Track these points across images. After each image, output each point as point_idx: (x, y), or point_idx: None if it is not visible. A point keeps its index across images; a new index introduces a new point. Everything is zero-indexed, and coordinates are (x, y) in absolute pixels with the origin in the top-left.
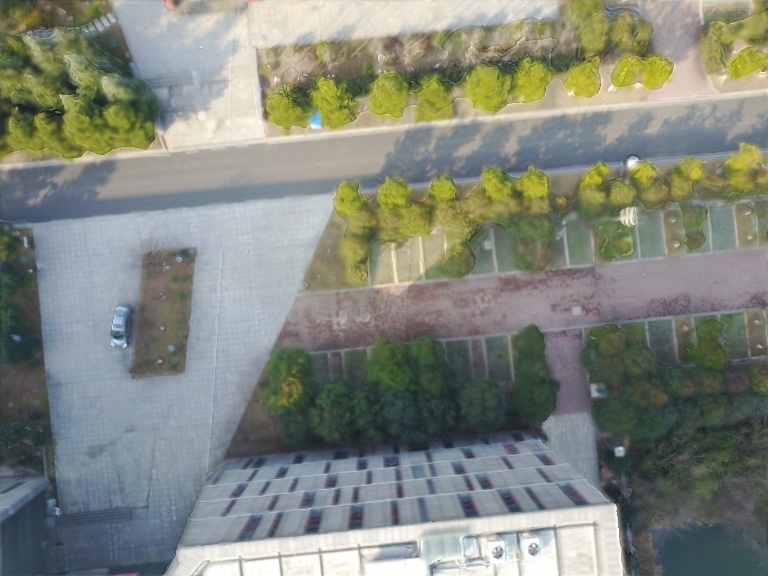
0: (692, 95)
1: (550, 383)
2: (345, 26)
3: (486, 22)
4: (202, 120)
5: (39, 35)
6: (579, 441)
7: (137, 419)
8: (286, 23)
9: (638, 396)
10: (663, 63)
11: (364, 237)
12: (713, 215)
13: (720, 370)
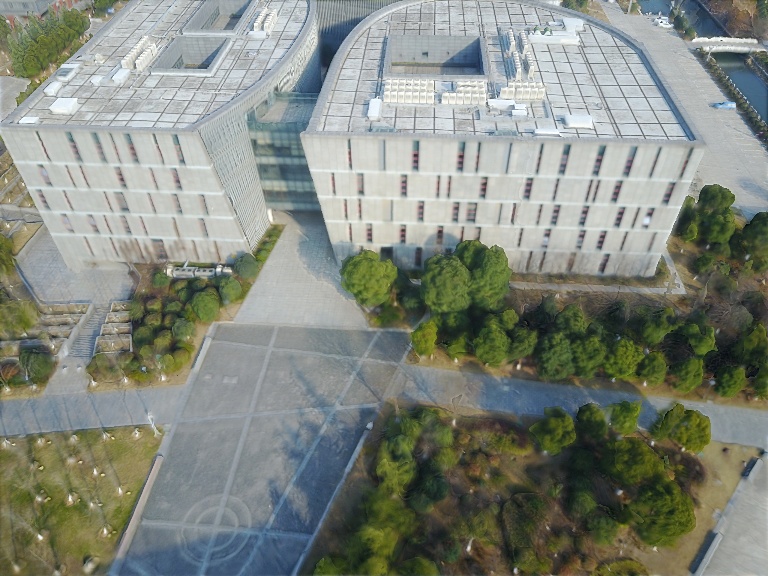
0: None
1: None
2: None
3: None
4: None
5: None
6: None
7: None
8: None
9: None
10: None
11: None
12: None
13: None
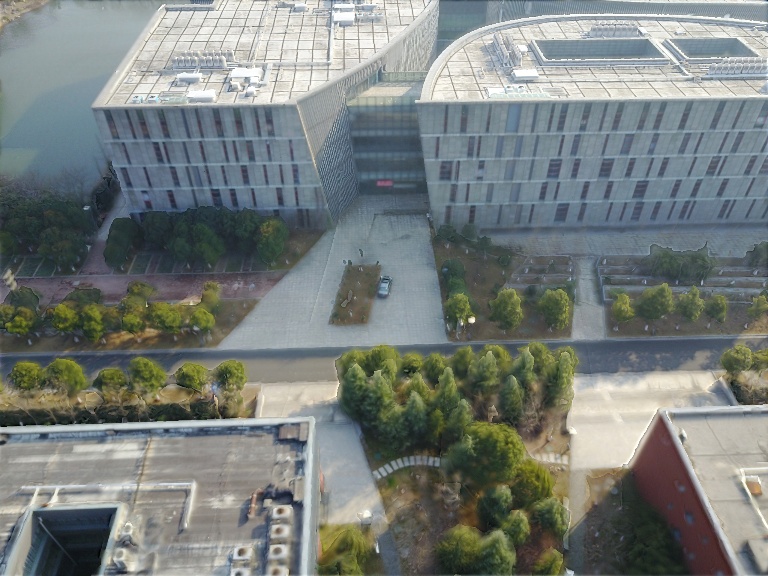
0: None
1: None
2: None
3: None
4: None
5: (433, 446)
6: None
7: (378, 248)
8: None
9: (61, 217)
10: None
11: None
12: None
13: None
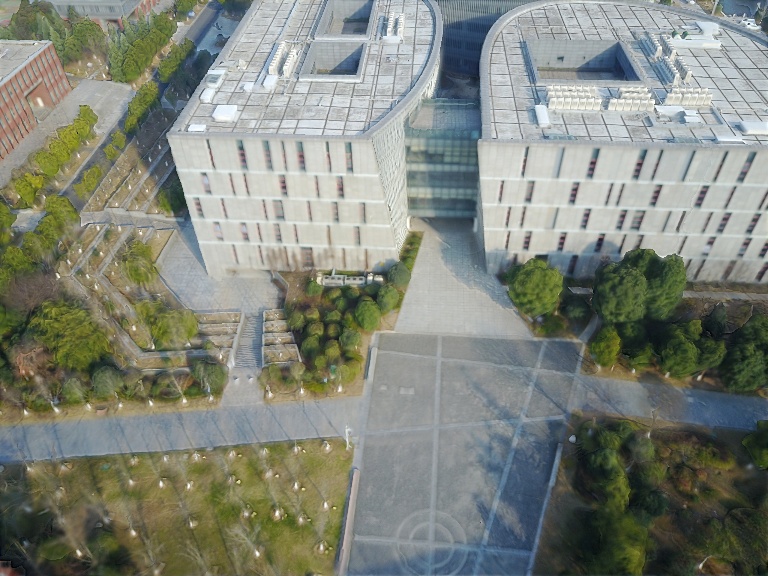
0: None
1: None
2: None
3: None
4: (174, 34)
5: None
6: None
7: None
8: None
9: None
10: None
11: None
12: None
13: None
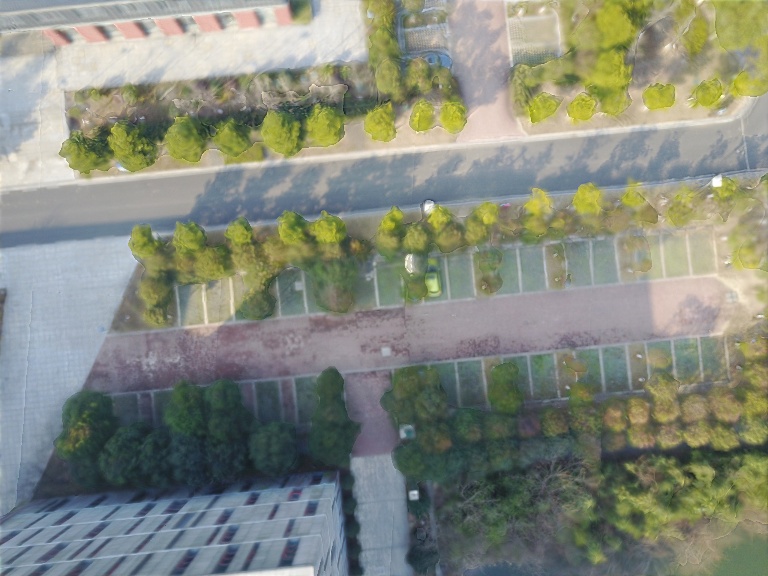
0: (501, 137)
1: (344, 427)
2: (153, 69)
3: (295, 65)
4: (13, 162)
5: None
6: (388, 482)
7: None
8: (95, 66)
9: (425, 441)
10: (454, 109)
11: (161, 280)
12: (523, 256)
13: (512, 414)
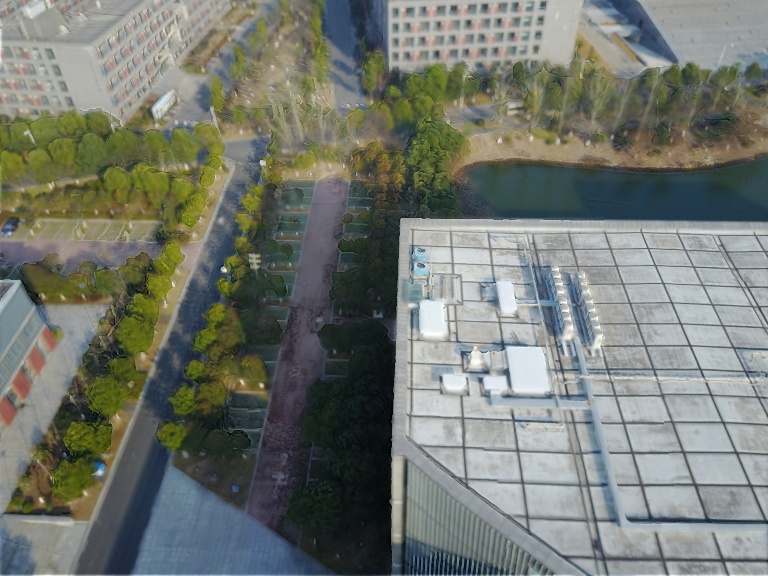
0: (198, 250)
1: None
2: (31, 438)
3: (88, 346)
4: None
5: None
6: None
7: None
8: None
9: (376, 273)
10: (168, 246)
11: None
12: None
13: None
